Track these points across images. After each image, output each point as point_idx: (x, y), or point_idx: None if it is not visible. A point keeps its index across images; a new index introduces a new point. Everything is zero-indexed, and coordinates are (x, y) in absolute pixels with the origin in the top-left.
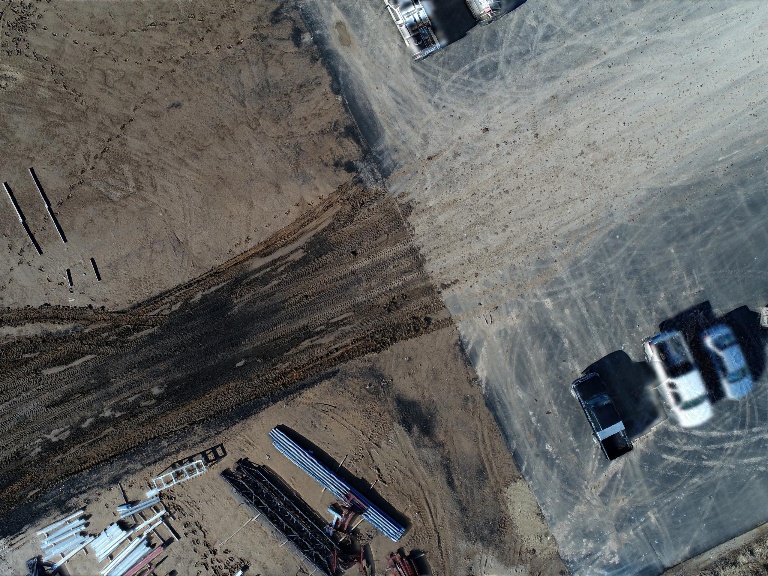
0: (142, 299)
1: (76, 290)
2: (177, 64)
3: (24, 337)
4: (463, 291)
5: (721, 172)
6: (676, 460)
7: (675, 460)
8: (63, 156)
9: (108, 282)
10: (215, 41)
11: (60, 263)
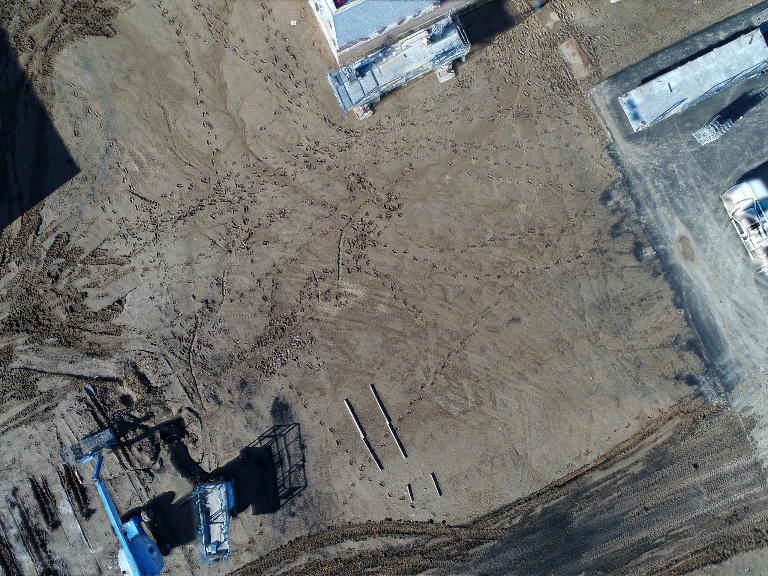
0: (482, 513)
1: (417, 505)
2: (517, 279)
3: (365, 551)
4: None
5: None
6: None
7: None
8: (403, 372)
9: (449, 497)
10: (555, 255)
11: (401, 478)
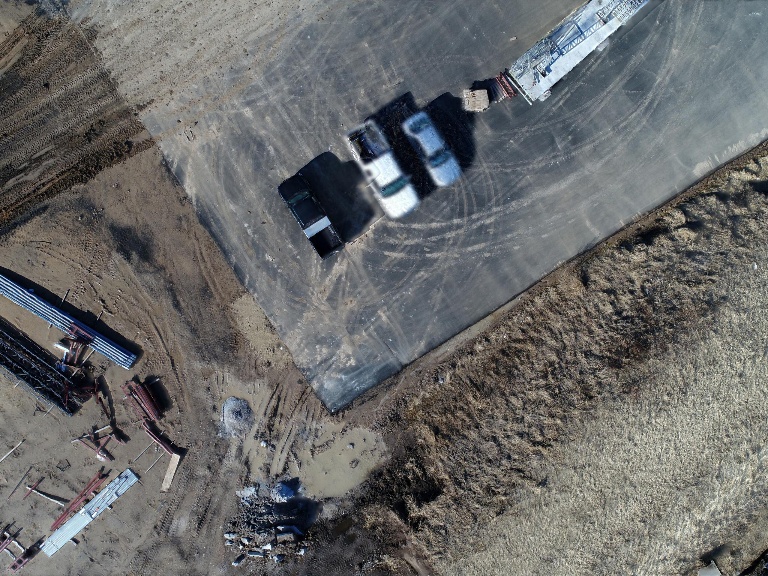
0: None
1: None
2: None
3: None
4: (160, 110)
5: None
6: (399, 256)
7: (398, 256)
8: None
9: None
10: None
11: None
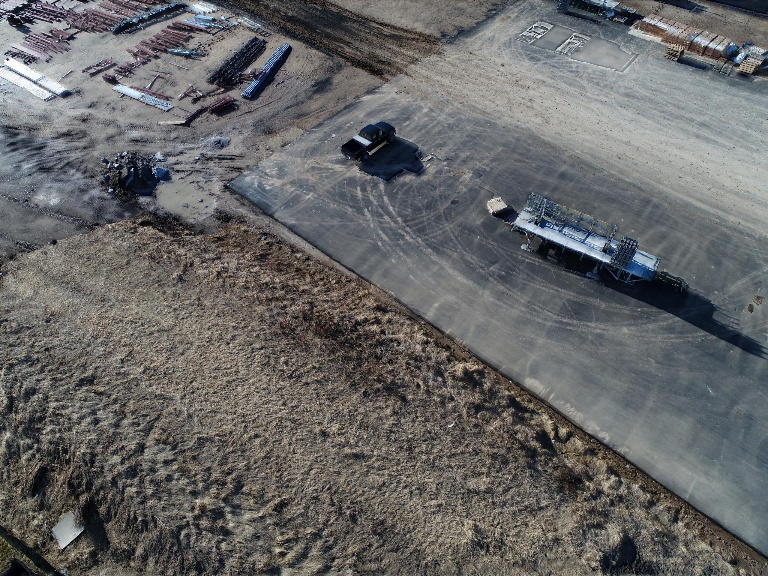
0: (333, 3)
1: None
2: None
3: None
4: (408, 80)
5: (569, 154)
6: (359, 194)
7: (359, 194)
8: None
9: None
10: None
11: None
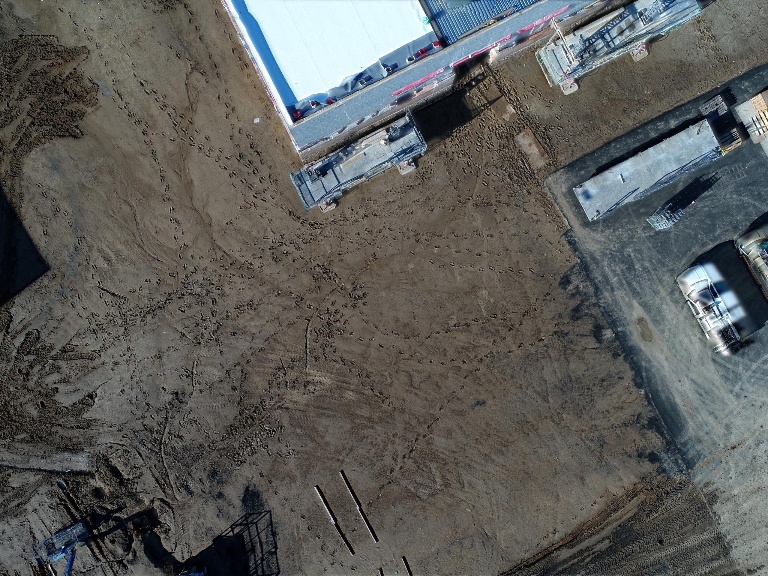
0: None
1: None
2: (481, 363)
3: None
4: None
5: None
6: None
7: None
8: (372, 457)
9: None
10: (517, 339)
11: (372, 562)
